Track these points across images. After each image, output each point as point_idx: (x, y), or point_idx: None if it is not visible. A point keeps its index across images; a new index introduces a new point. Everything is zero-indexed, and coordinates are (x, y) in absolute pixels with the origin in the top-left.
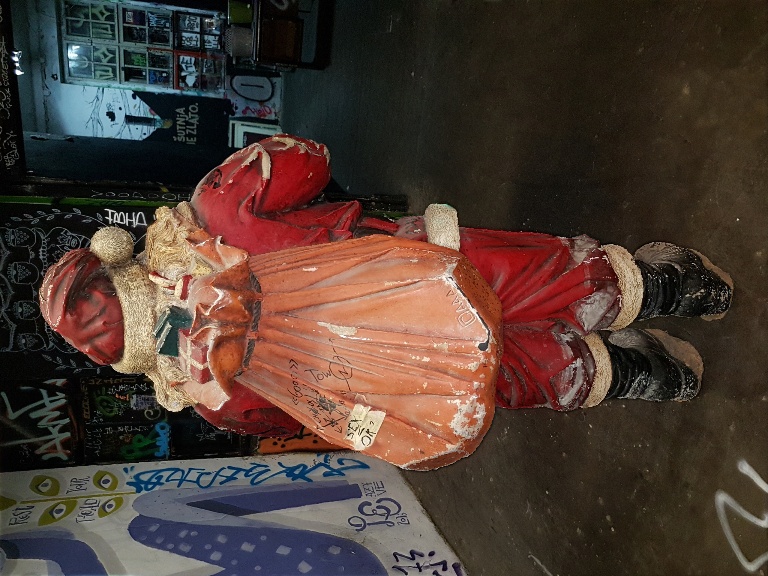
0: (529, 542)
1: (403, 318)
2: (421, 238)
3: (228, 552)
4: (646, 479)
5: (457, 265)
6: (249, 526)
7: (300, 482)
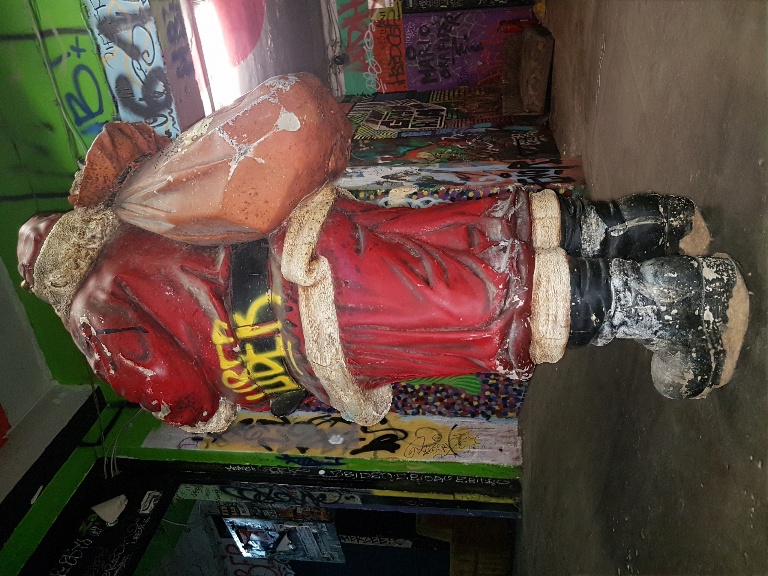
0: None
1: None
2: None
3: None
4: None
5: None
6: None
7: None
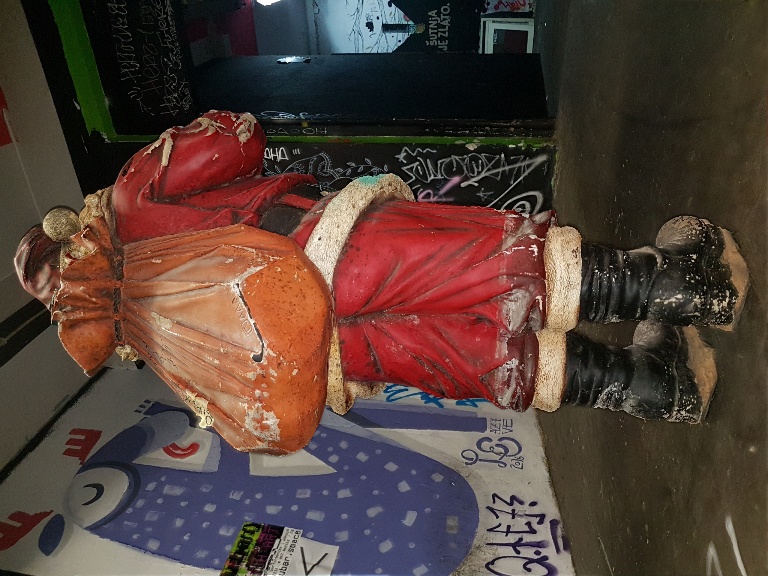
0: (599, 524)
1: (204, 319)
2: (310, 222)
3: (344, 458)
4: (672, 499)
5: (263, 268)
6: (370, 438)
7: (431, 406)
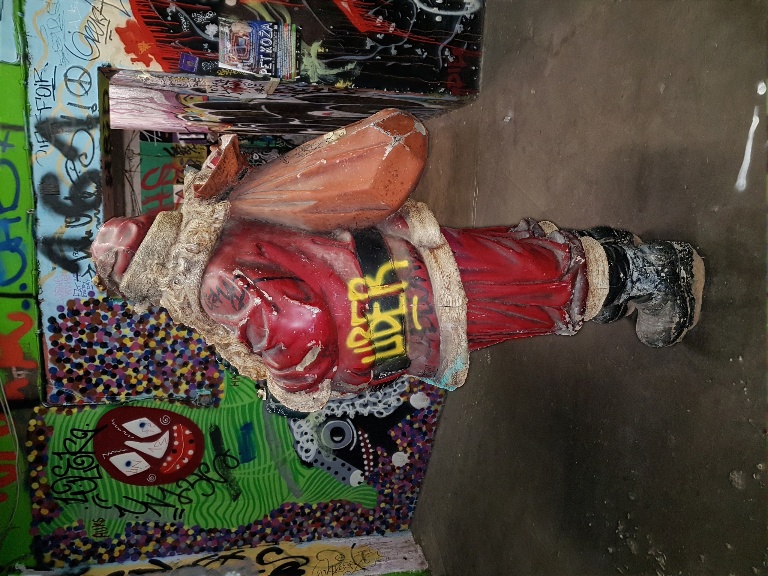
0: None
1: None
2: None
3: None
4: None
5: None
6: None
7: None
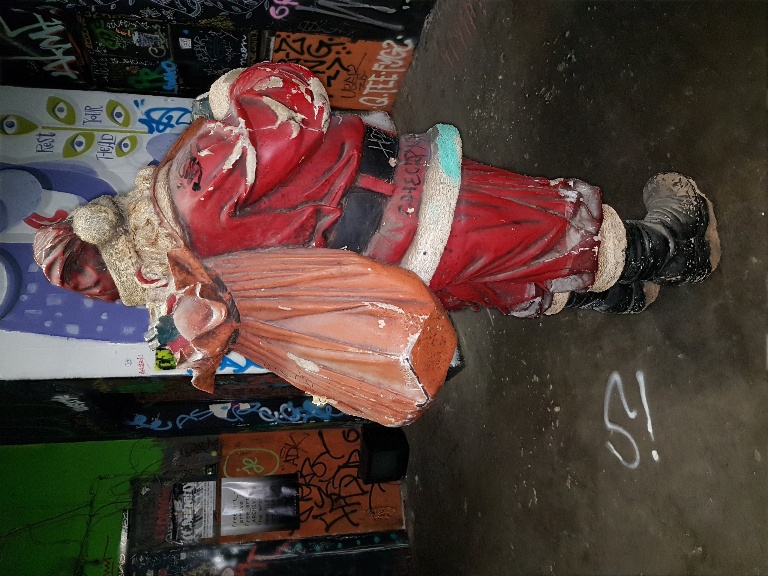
0: None
1: (360, 371)
2: (410, 230)
3: None
4: (578, 319)
5: (420, 335)
6: None
7: None
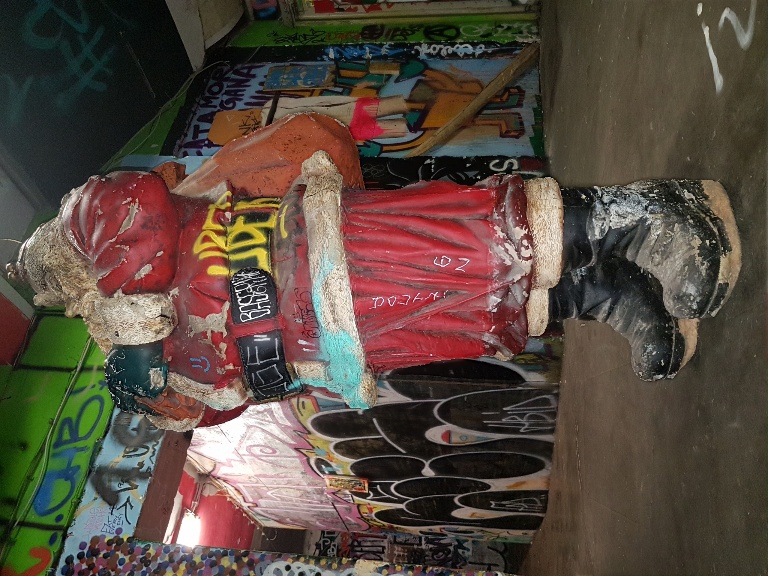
0: None
1: None
2: None
3: None
4: None
5: None
6: None
7: None
